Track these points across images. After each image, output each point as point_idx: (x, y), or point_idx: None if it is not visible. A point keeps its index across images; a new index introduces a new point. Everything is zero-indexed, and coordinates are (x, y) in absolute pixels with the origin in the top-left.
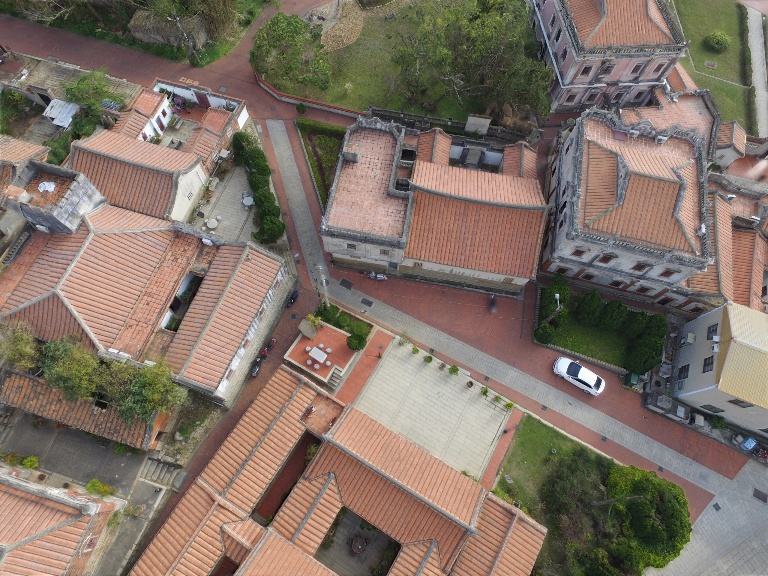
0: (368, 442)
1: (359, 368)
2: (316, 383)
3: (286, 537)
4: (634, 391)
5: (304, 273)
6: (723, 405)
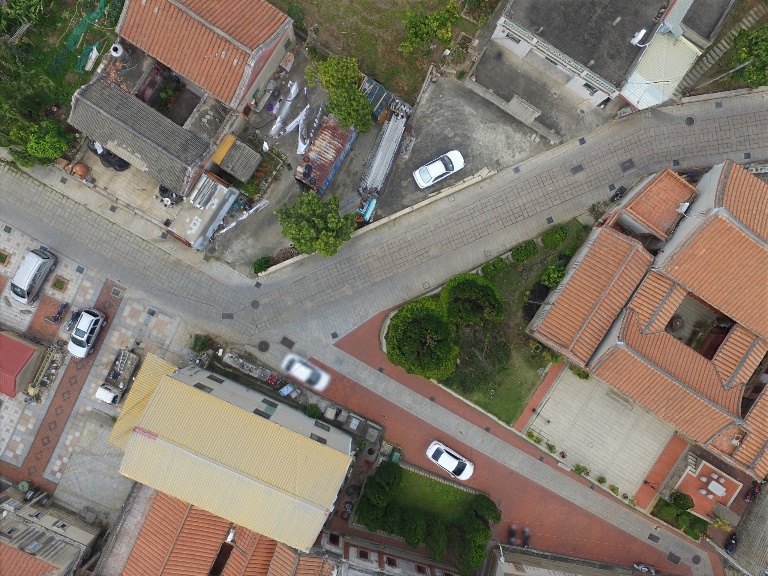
0: (696, 415)
1: (666, 471)
2: (707, 458)
3: (761, 340)
4: (390, 443)
5: (718, 571)
6: (322, 433)
